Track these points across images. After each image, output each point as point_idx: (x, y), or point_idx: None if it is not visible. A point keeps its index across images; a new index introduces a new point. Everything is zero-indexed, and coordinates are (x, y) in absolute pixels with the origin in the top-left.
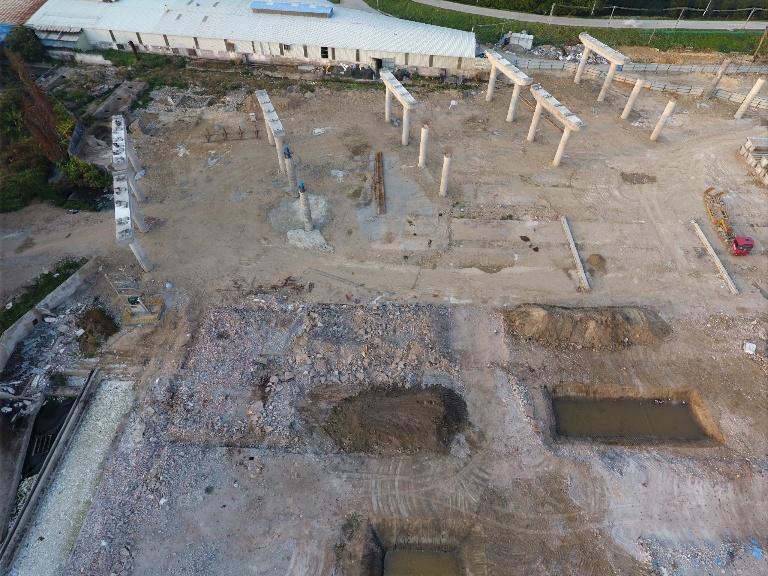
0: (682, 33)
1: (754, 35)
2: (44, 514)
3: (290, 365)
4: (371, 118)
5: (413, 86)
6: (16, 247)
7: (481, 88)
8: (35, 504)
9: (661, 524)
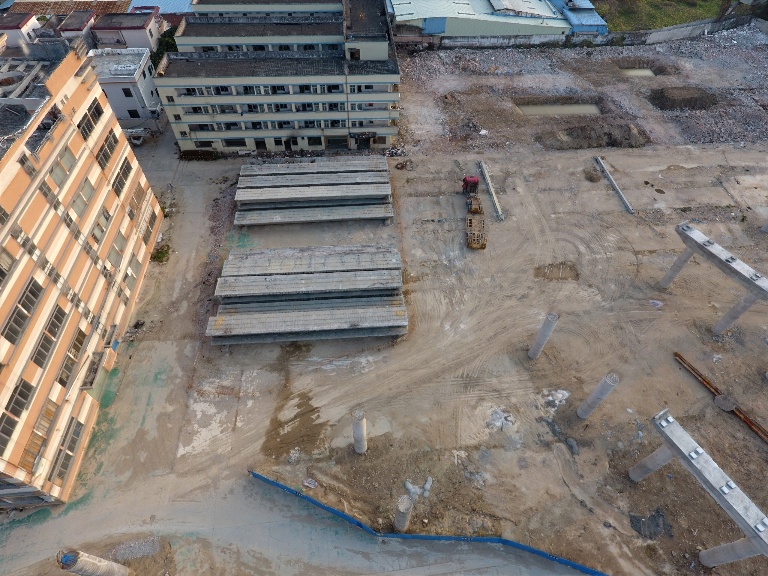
0: None
1: None
2: None
3: None
4: None
5: None
6: None
7: None
8: None
9: (549, 77)
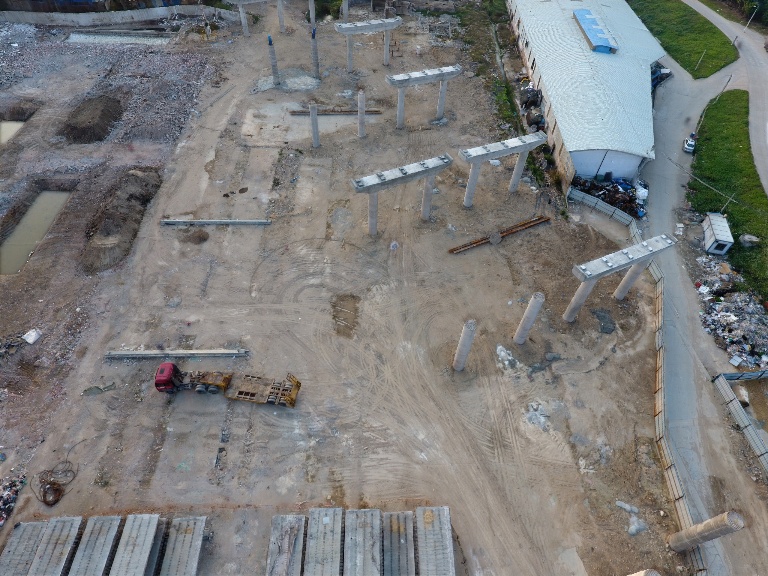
0: None
1: None
2: (106, 37)
3: None
4: None
5: None
6: (275, 5)
7: (545, 188)
8: (110, 32)
9: None
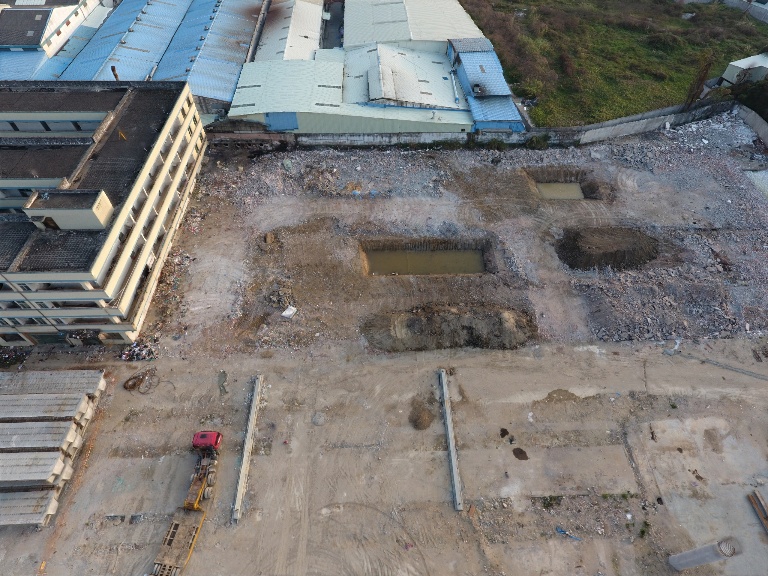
0: None
1: None
2: None
3: None
4: None
5: None
6: None
7: None
8: None
9: (426, 202)
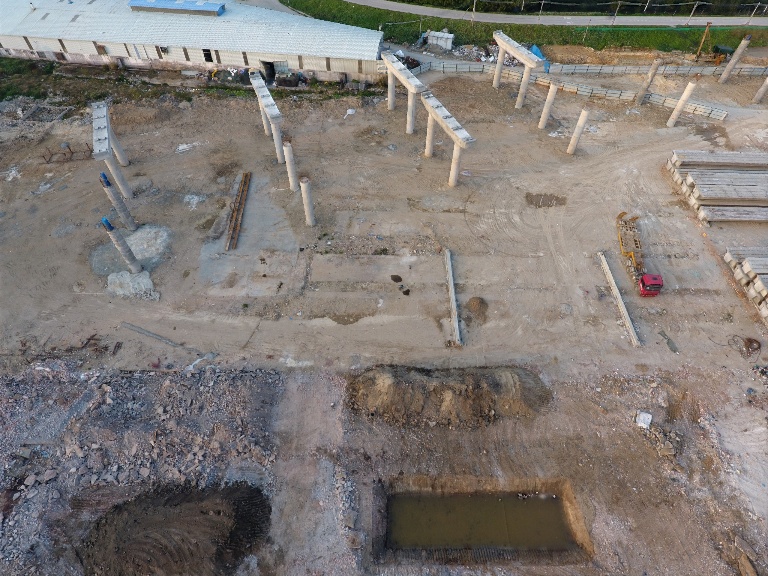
0: (620, 30)
1: (699, 32)
2: None
3: (58, 459)
4: (250, 131)
5: (309, 93)
6: None
7: (386, 94)
8: None
9: None
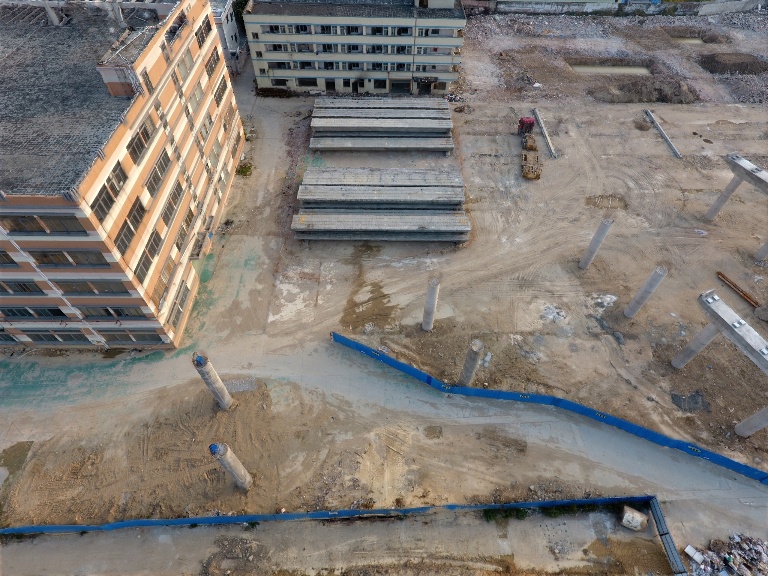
0: None
1: None
2: None
3: None
4: None
5: None
6: None
7: None
8: None
9: None
